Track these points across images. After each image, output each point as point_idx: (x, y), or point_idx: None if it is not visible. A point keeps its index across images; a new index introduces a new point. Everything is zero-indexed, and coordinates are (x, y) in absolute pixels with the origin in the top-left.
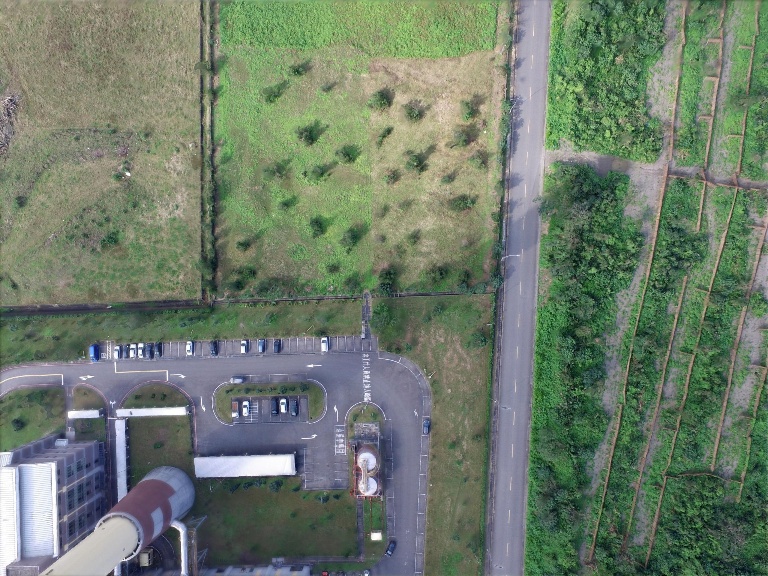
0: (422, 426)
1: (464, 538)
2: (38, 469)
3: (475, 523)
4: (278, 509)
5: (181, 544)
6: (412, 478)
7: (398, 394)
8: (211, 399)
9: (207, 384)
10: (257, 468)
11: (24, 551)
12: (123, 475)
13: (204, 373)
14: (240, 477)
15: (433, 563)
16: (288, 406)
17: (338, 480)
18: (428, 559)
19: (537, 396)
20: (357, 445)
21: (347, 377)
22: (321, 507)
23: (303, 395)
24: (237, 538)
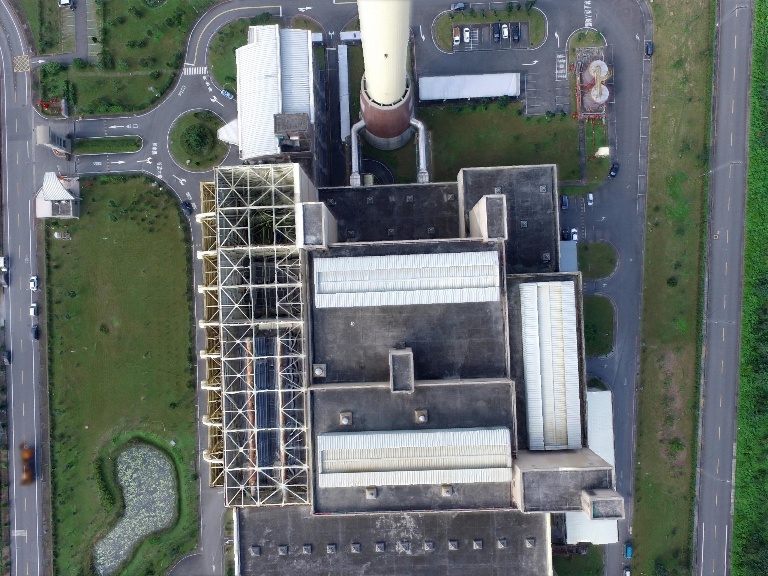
0: (644, 50)
1: (688, 158)
2: (296, 34)
3: (698, 144)
4: (499, 134)
5: (419, 141)
6: (634, 102)
7: (619, 19)
8: (431, 28)
9: (427, 13)
10: (482, 87)
11: (283, 112)
12: (345, 99)
13: (423, 2)
14: (461, 104)
15: (656, 185)
16: (509, 33)
17: (560, 105)
18: (651, 181)
19: (760, 17)
20: (582, 64)
21: (568, 3)
22: (543, 131)
23: (524, 22)
24: (458, 164)
